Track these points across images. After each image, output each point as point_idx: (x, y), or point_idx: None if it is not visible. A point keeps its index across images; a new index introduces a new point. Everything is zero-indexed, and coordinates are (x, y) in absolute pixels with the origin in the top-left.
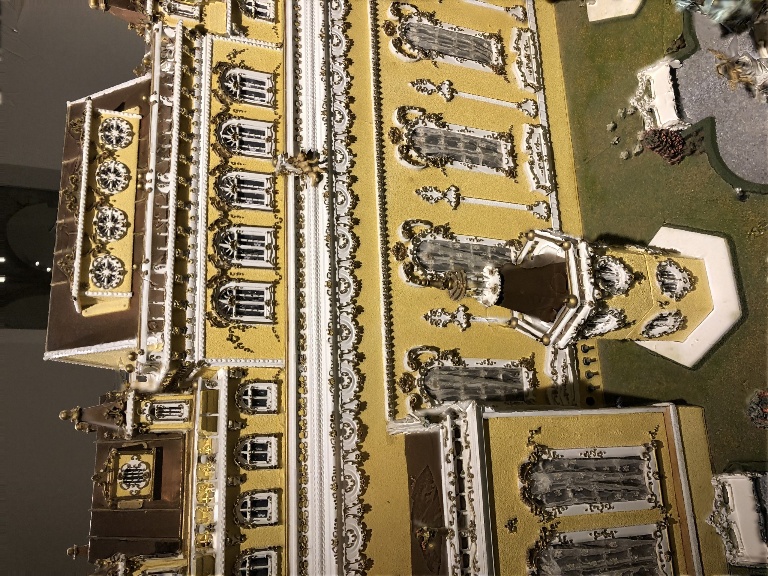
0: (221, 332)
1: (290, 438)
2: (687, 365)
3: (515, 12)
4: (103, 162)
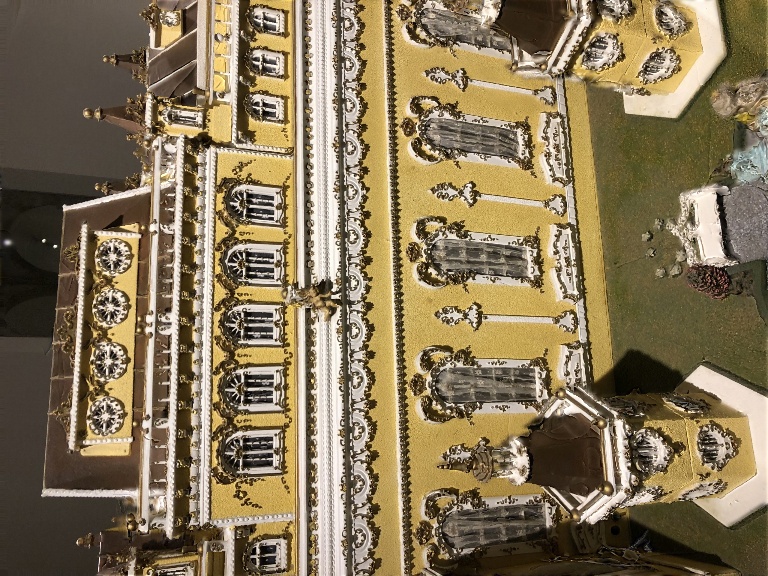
0: (227, 488)
1: None
2: (724, 524)
3: (544, 95)
4: (100, 291)
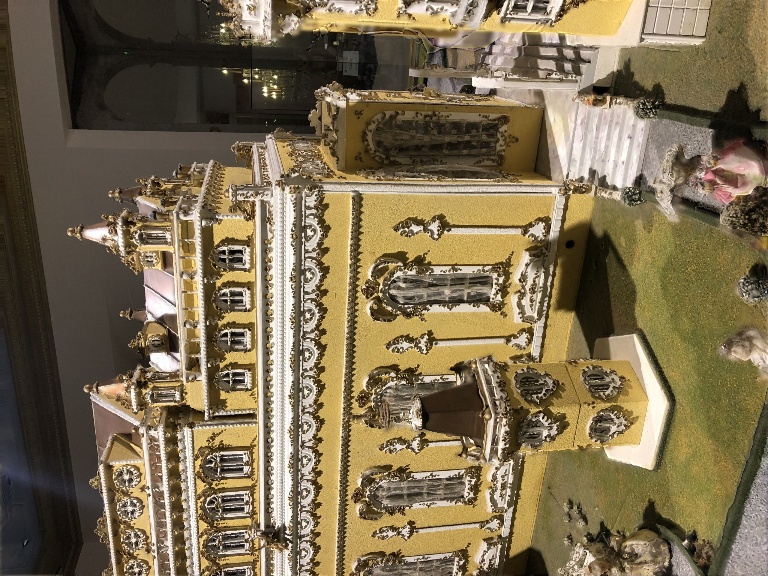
0: None
1: None
2: None
3: (517, 341)
4: (121, 500)
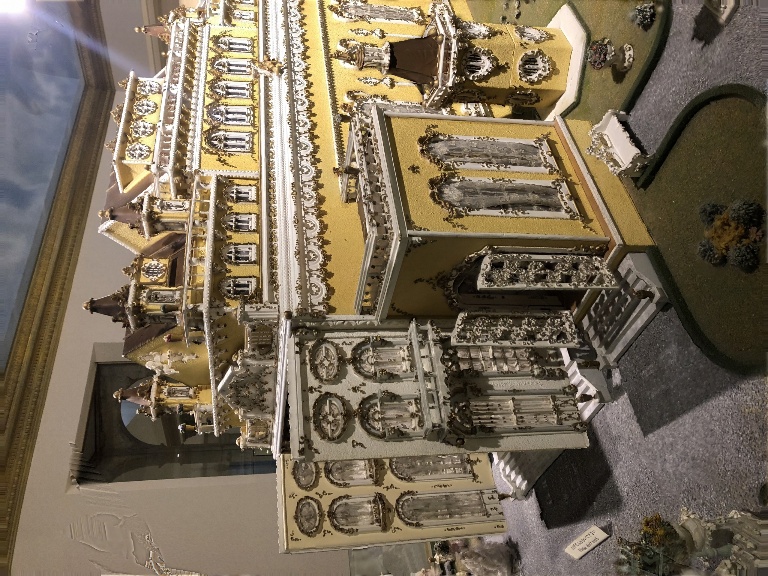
0: (212, 157)
1: (262, 204)
2: (572, 101)
3: None
4: (139, 101)
